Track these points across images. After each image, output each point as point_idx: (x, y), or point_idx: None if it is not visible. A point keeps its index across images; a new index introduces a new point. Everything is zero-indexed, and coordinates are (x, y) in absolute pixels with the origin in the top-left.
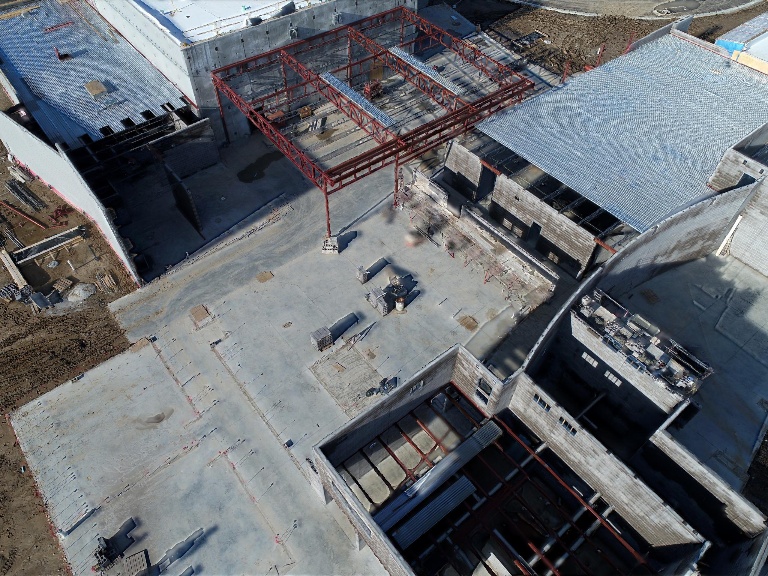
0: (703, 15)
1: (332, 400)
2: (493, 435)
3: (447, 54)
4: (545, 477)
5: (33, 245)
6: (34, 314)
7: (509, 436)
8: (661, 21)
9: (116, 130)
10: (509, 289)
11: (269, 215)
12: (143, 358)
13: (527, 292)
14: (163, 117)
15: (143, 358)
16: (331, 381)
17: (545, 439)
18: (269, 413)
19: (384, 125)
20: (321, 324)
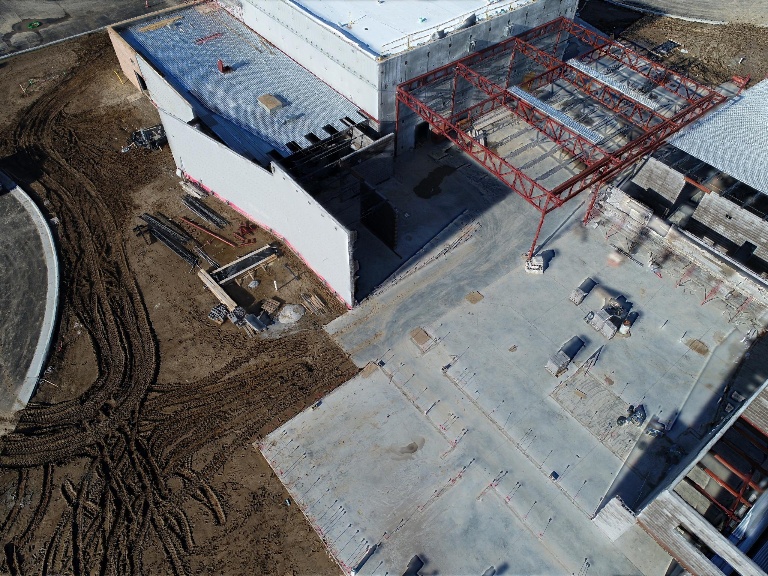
0: None
1: (584, 429)
2: None
3: None
4: None
5: (230, 264)
6: (251, 337)
7: None
8: None
9: (303, 146)
10: (739, 312)
11: (459, 232)
12: (377, 384)
13: (760, 315)
14: (345, 132)
15: (377, 384)
16: (577, 409)
17: None
18: (524, 443)
19: (592, 141)
20: (548, 348)
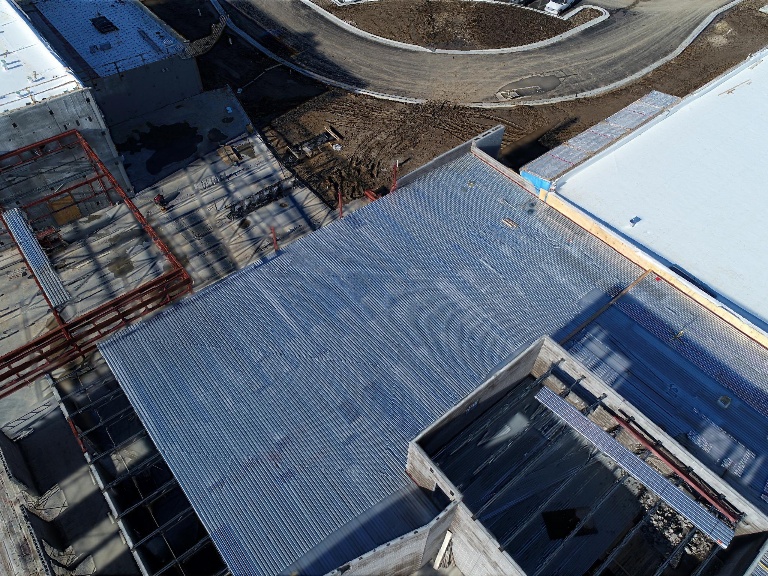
0: (558, 100)
1: None
2: None
3: (192, 171)
4: None
5: None
6: None
7: None
8: (500, 111)
9: None
10: None
11: None
12: None
13: None
14: None
15: None
16: None
17: None
18: None
19: None
20: None
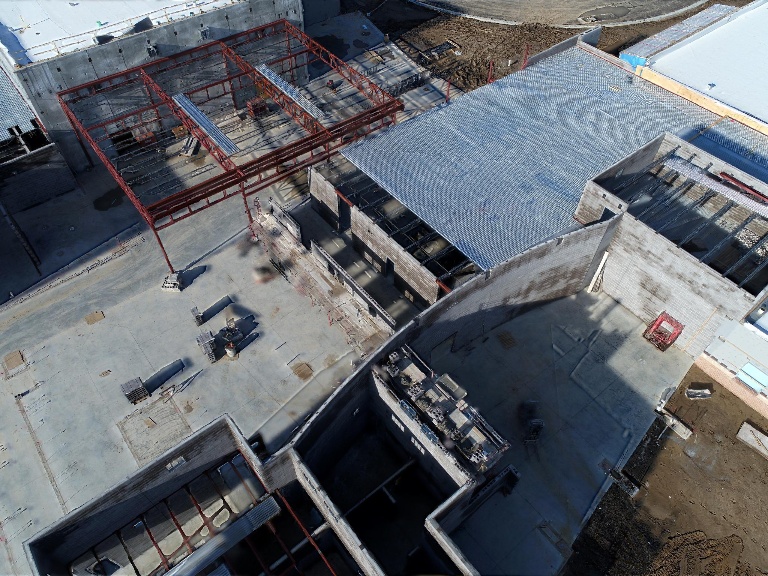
0: (629, 23)
1: (133, 461)
2: (269, 514)
3: None
4: (342, 554)
5: None
6: None
7: (289, 514)
8: (583, 30)
9: None
10: (348, 334)
11: (116, 247)
12: None
13: (365, 338)
14: (8, 142)
15: None
16: (137, 439)
17: (326, 518)
18: (60, 477)
19: (227, 153)
20: (142, 372)
